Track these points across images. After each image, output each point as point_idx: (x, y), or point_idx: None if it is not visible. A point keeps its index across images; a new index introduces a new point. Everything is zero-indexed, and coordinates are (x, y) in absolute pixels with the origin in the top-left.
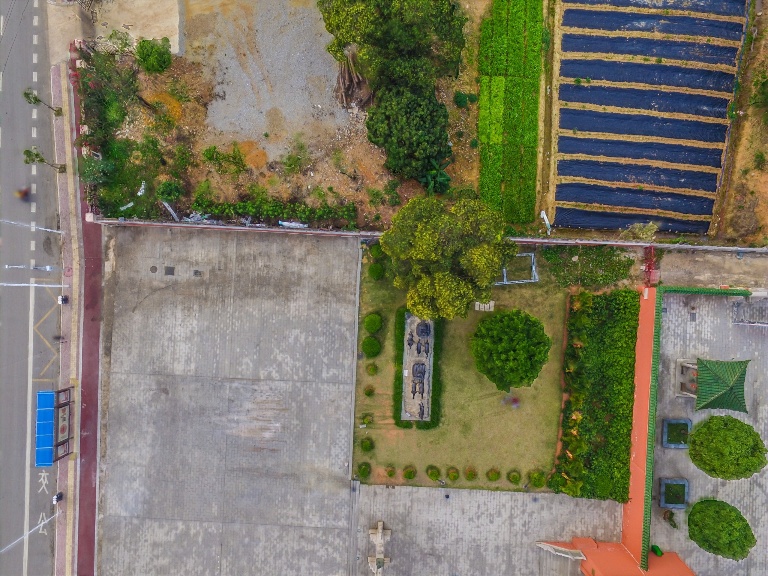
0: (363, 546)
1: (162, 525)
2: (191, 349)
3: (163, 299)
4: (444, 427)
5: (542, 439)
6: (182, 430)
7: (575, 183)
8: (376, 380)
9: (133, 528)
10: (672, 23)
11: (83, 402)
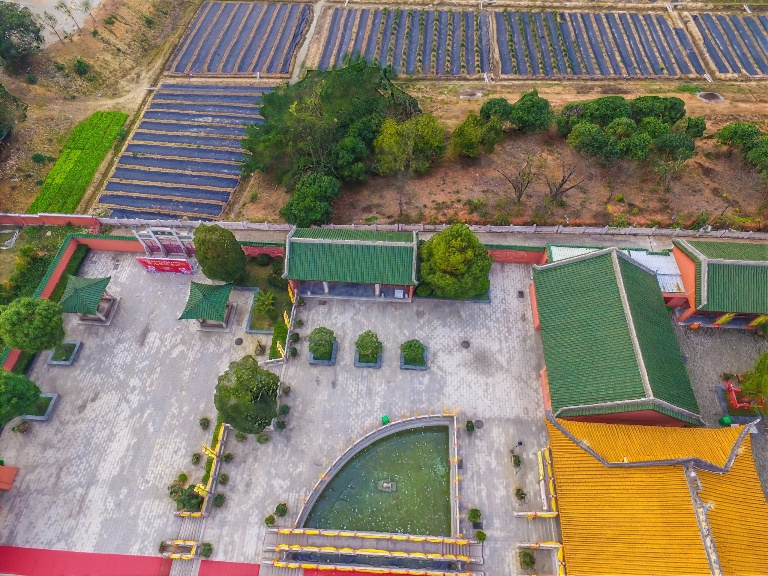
0: None
1: None
2: None
3: None
4: None
5: None
6: None
7: (109, 208)
8: None
9: None
10: (215, 130)
11: None
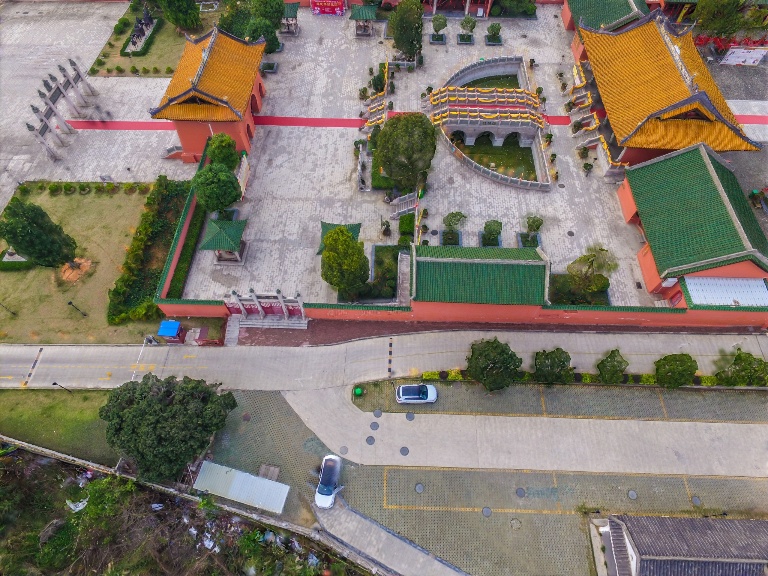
0: None
1: None
2: (21, 36)
3: (16, 21)
4: (148, 56)
5: None
6: None
7: None
8: None
9: None
10: None
11: None
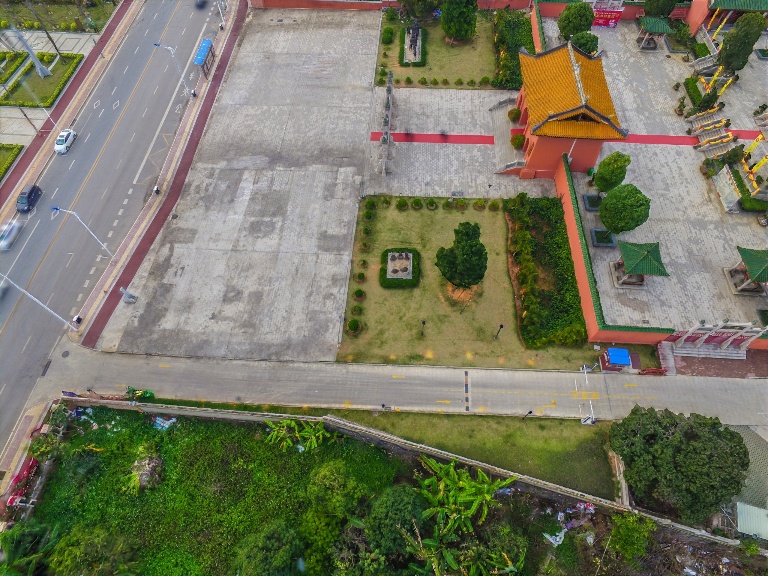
0: (379, 111)
1: (254, 107)
2: (286, 44)
3: (274, 29)
4: (428, 67)
5: (486, 69)
6: (275, 72)
7: None
8: (389, 52)
9: (235, 109)
10: None
11: (220, 62)
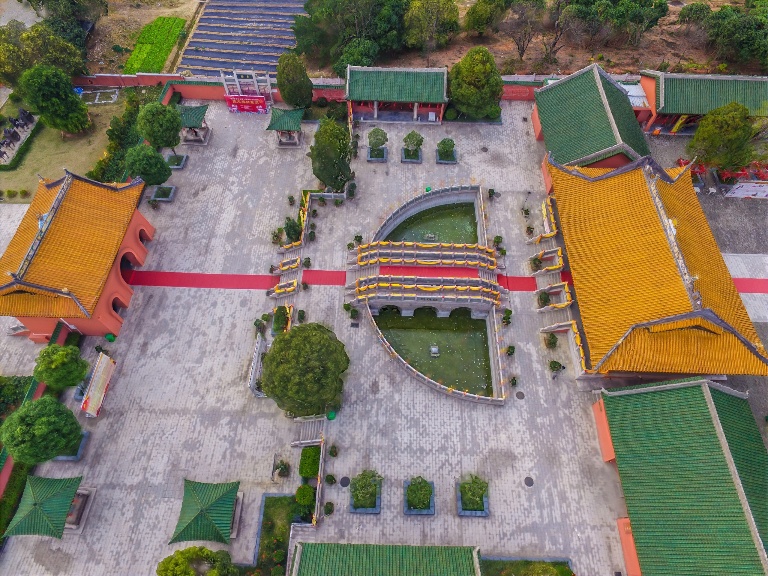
0: None
1: None
2: None
3: None
4: (20, 170)
5: None
6: None
7: None
8: None
9: None
10: None
11: None
